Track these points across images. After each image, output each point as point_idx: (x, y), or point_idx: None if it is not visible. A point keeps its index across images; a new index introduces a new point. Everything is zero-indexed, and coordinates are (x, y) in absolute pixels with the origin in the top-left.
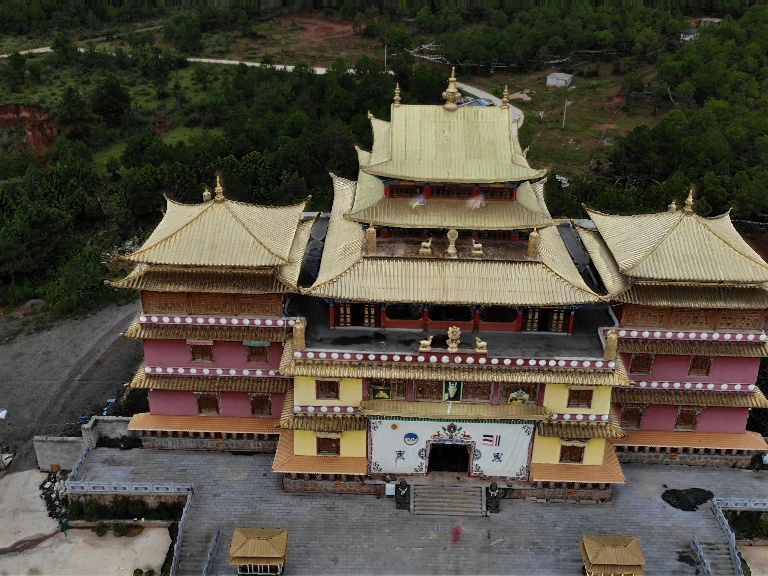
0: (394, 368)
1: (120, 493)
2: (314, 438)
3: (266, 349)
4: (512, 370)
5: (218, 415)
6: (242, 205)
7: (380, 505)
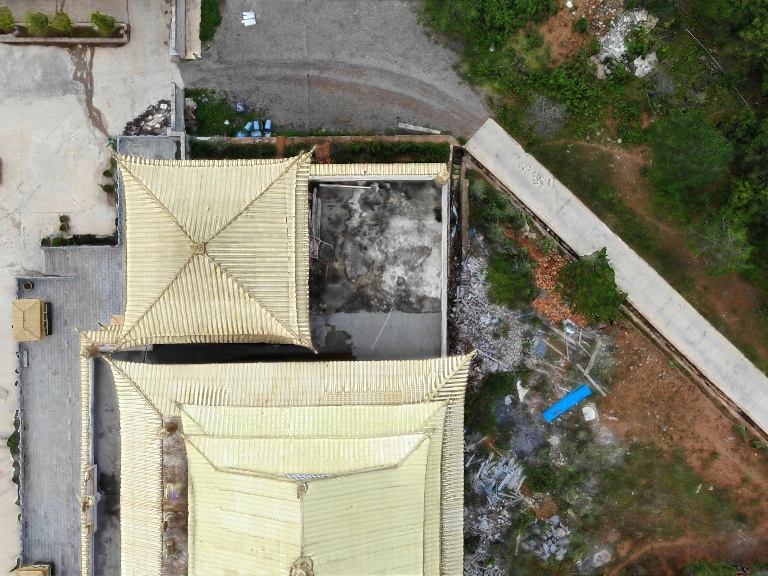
0: None
1: None
2: None
3: None
4: None
5: None
6: (221, 272)
7: None
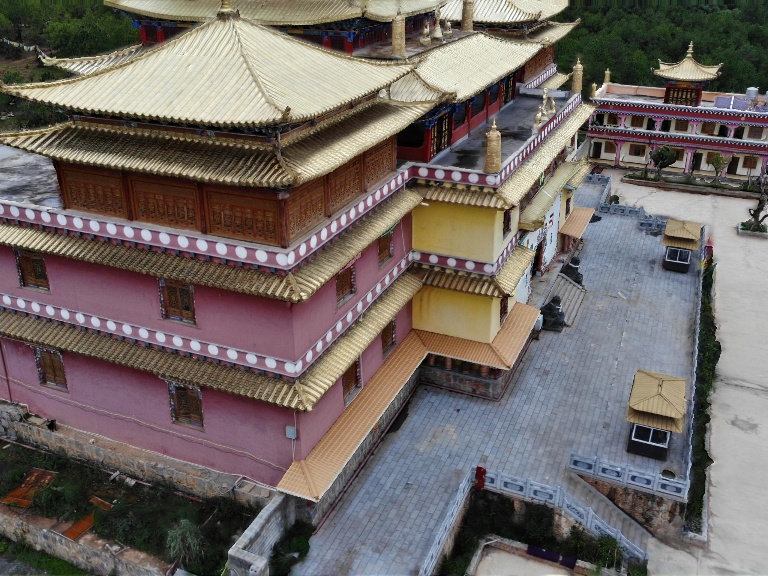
0: (535, 158)
1: (430, 573)
2: (499, 304)
3: (389, 234)
4: (562, 126)
5: (359, 389)
6: None
7: (551, 341)
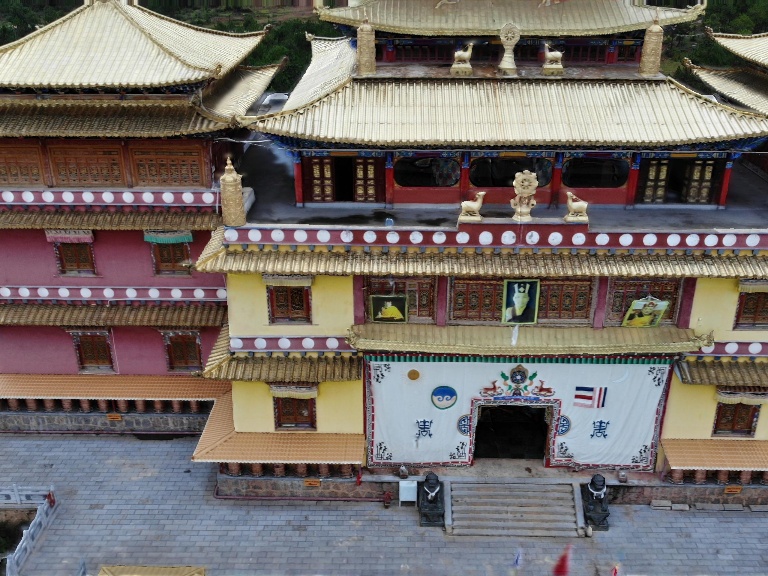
0: (412, 257)
1: None
2: (269, 399)
3: (187, 249)
4: (635, 256)
5: (112, 372)
6: (148, 14)
7: (390, 519)
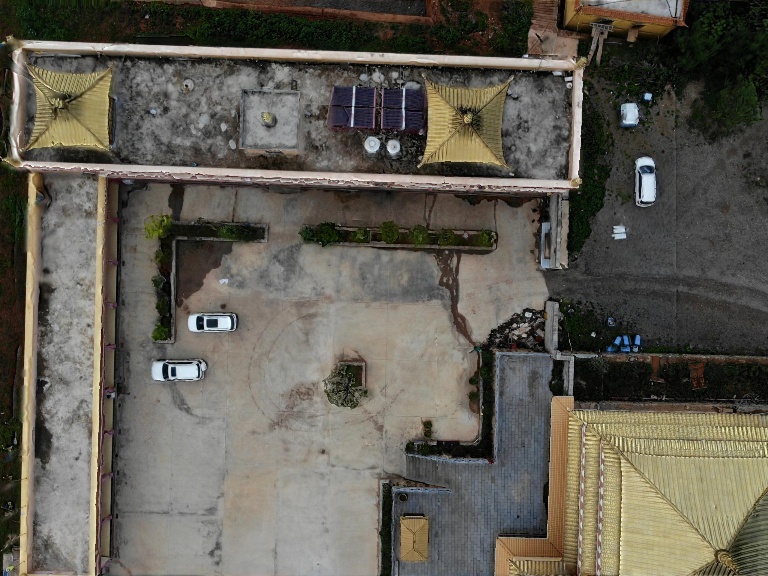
0: None
1: None
2: None
3: None
4: None
5: None
6: (733, 574)
7: None
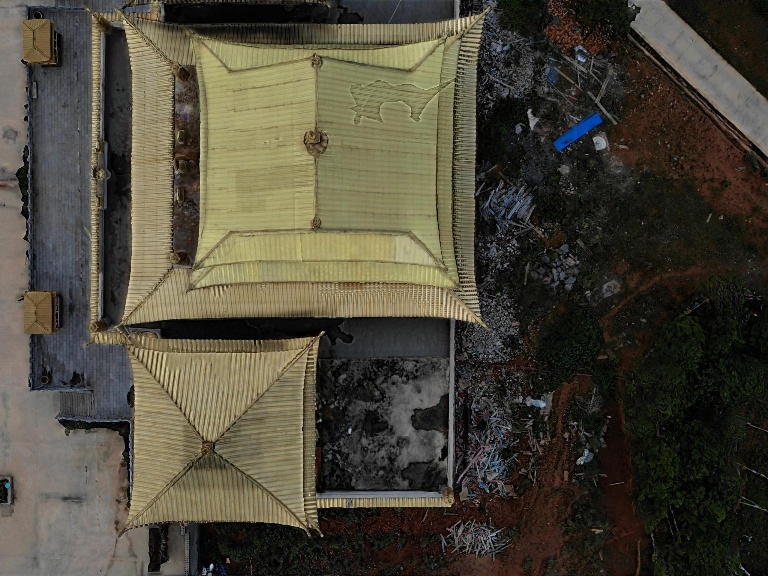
0: None
1: None
2: None
3: None
4: None
5: None
6: None
7: None
